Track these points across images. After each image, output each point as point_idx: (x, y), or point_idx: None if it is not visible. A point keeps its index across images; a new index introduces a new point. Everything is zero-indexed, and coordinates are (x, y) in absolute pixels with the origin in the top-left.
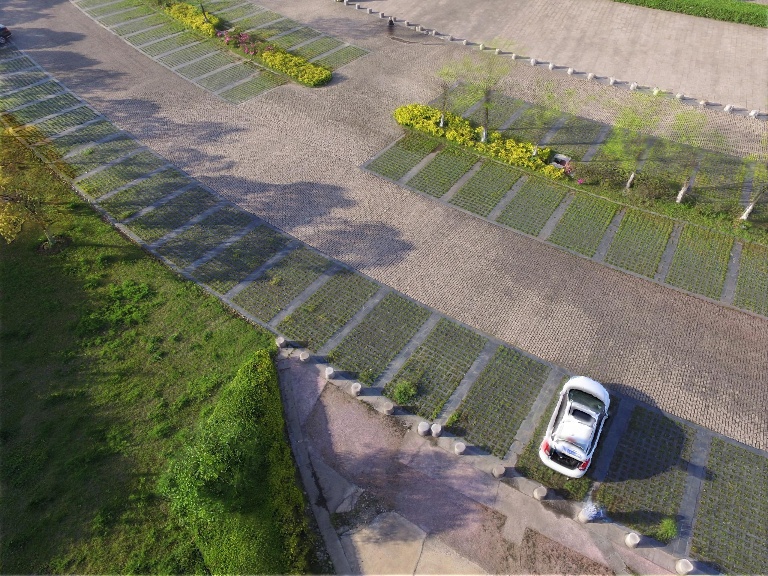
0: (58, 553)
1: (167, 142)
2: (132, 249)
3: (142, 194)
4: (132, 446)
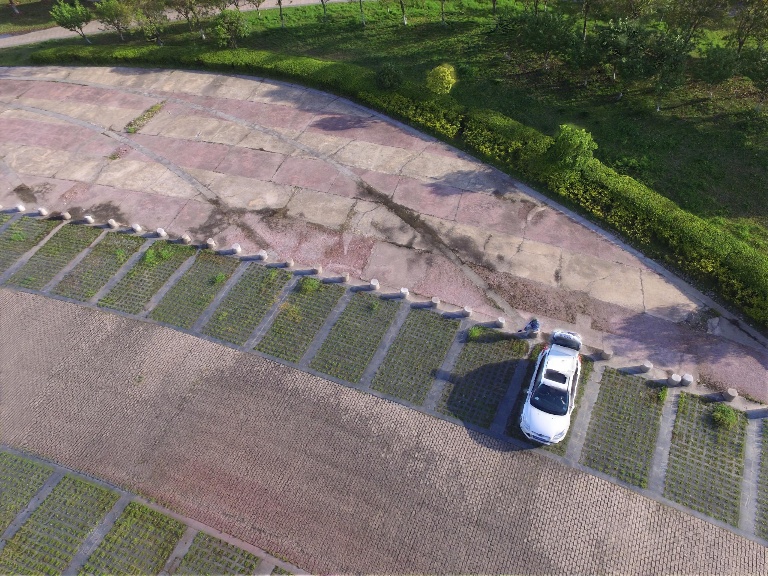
0: None
1: None
2: None
3: None
4: None
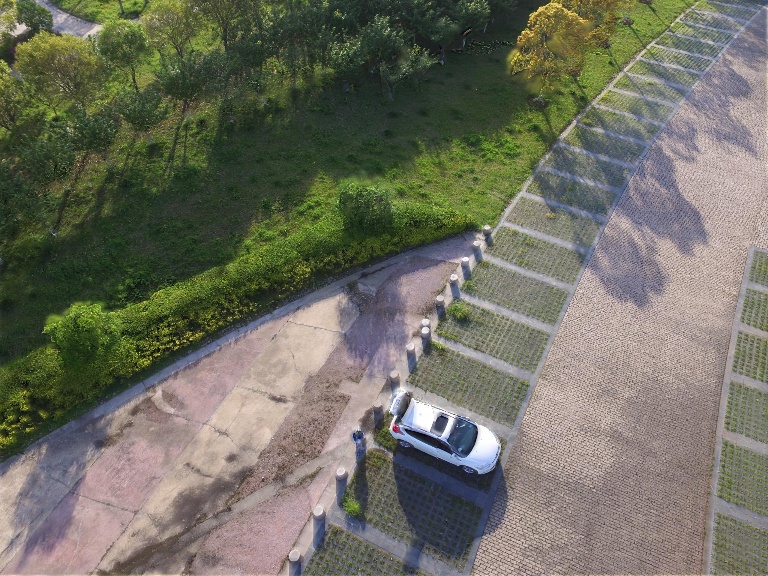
0: (328, 173)
1: (695, 114)
2: (552, 135)
3: (616, 122)
4: (390, 180)
